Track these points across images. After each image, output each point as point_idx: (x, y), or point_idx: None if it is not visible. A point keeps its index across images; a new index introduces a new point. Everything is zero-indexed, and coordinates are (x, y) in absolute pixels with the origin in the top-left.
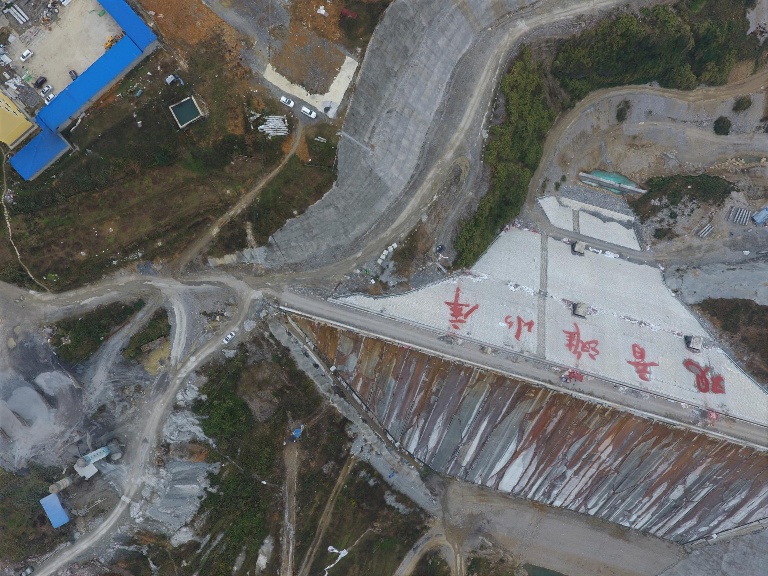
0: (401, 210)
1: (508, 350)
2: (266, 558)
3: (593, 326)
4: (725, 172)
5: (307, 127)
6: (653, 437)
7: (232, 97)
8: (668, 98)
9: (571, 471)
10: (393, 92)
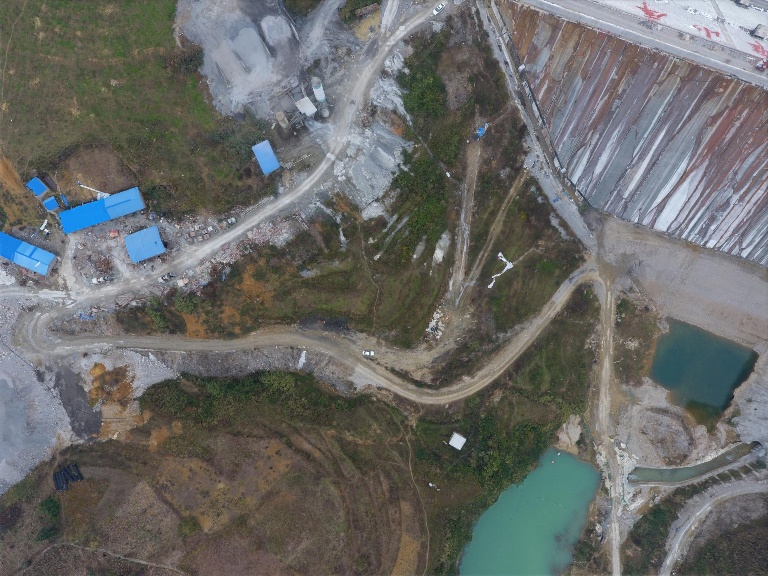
0: None
1: (705, 38)
2: (443, 252)
3: None
4: None
5: None
6: None
7: None
8: None
9: (737, 196)
10: None
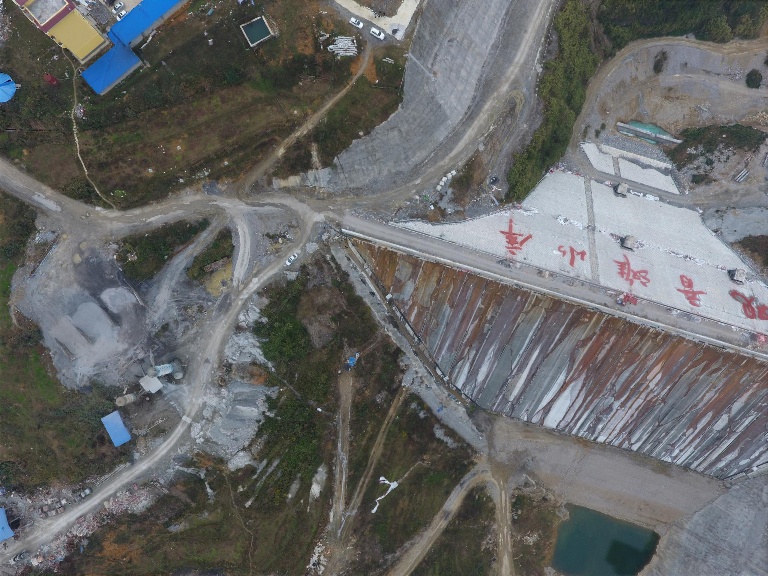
0: (459, 139)
1: (565, 274)
2: (320, 486)
3: (641, 258)
4: (756, 124)
5: (375, 48)
6: (703, 362)
7: (302, 18)
8: (703, 50)
9: (618, 403)
10: (454, 22)
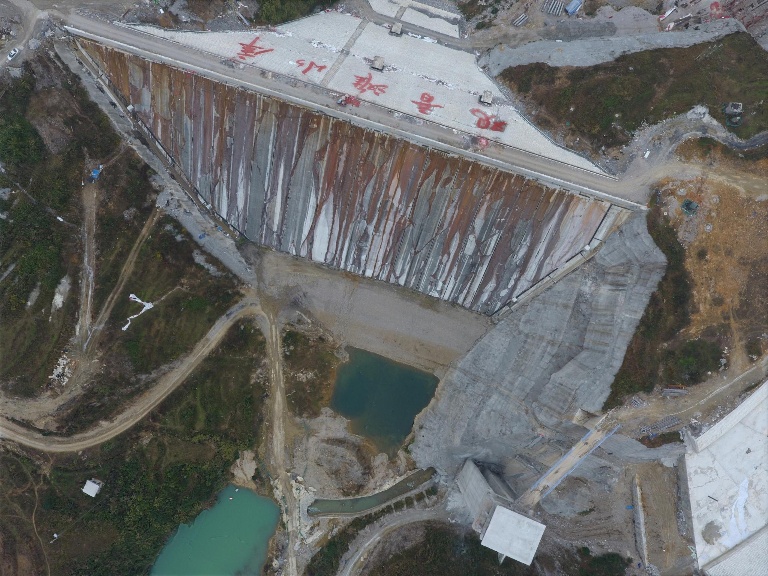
0: None
1: (288, 75)
2: (63, 297)
3: (388, 77)
4: None
5: None
6: (433, 171)
7: None
8: None
9: (371, 227)
10: None
